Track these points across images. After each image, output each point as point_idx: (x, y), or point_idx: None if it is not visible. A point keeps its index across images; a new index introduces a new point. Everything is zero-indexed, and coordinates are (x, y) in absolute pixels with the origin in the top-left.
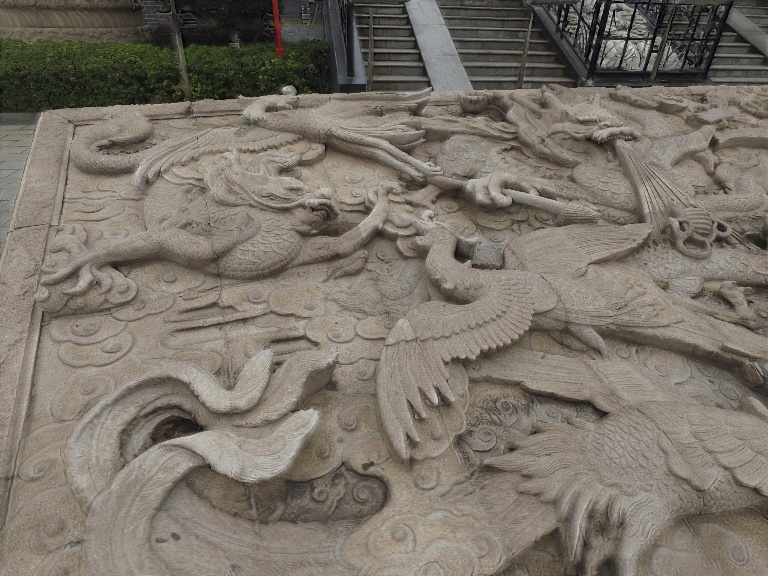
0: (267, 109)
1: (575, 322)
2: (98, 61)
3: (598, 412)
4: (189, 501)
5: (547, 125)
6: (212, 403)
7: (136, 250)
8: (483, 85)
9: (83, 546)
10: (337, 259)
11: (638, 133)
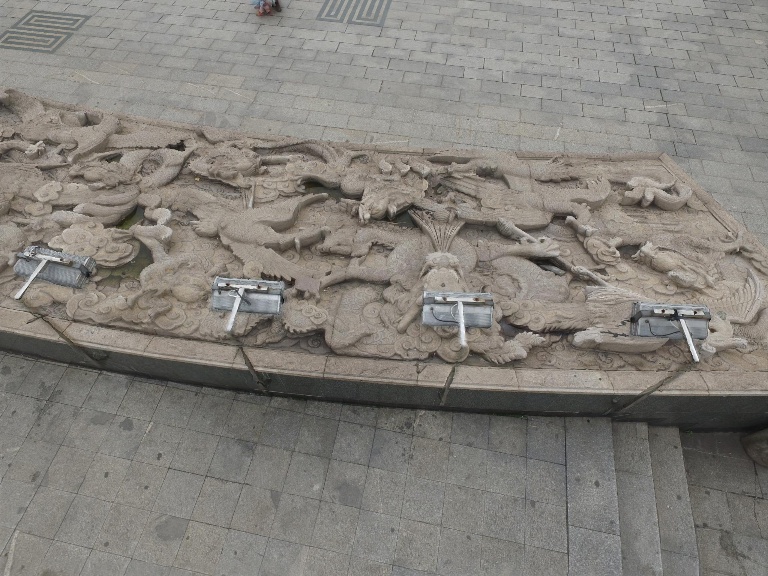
0: None
1: None
2: None
3: None
4: None
5: None
6: (658, 189)
7: None
8: None
9: None
10: None
11: None
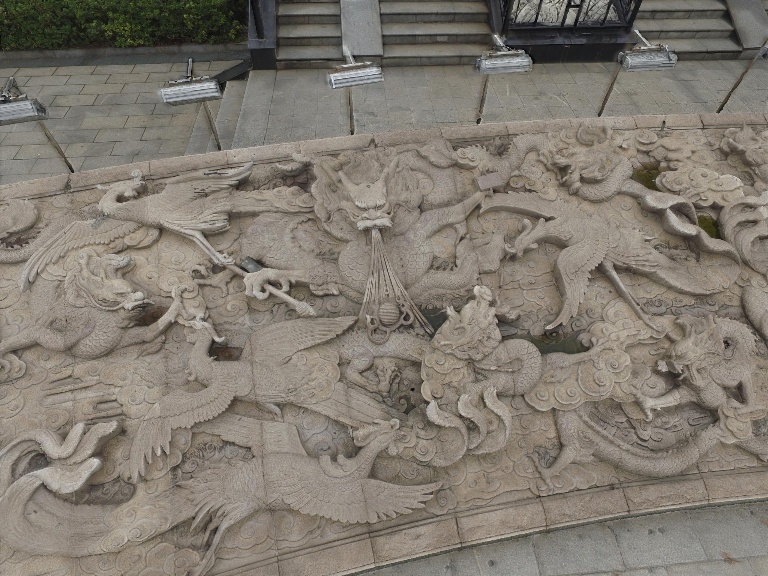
0: (117, 197)
1: (260, 401)
2: None
3: None
4: (44, 495)
5: (339, 200)
6: (50, 455)
7: (21, 345)
8: (398, 39)
9: None
10: (145, 343)
11: (389, 224)
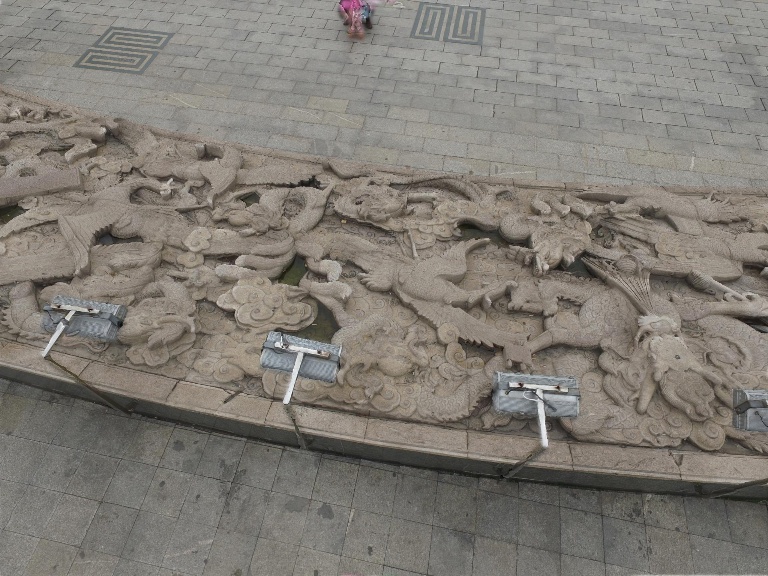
0: None
1: None
2: None
3: None
4: None
5: None
6: None
7: None
8: None
9: None
10: None
11: None
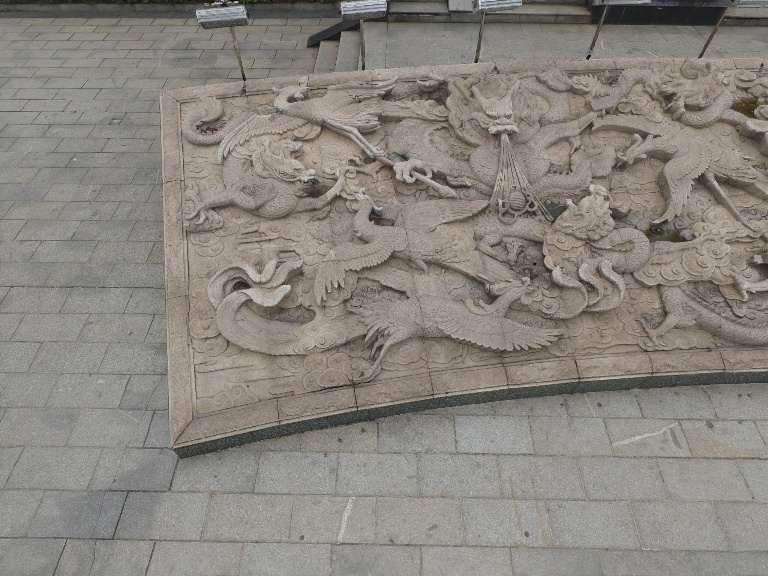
0: (288, 98)
1: (413, 257)
2: None
3: (407, 297)
4: (247, 310)
5: (470, 111)
6: (254, 279)
7: (222, 202)
8: None
9: (216, 319)
10: (315, 210)
11: (517, 130)
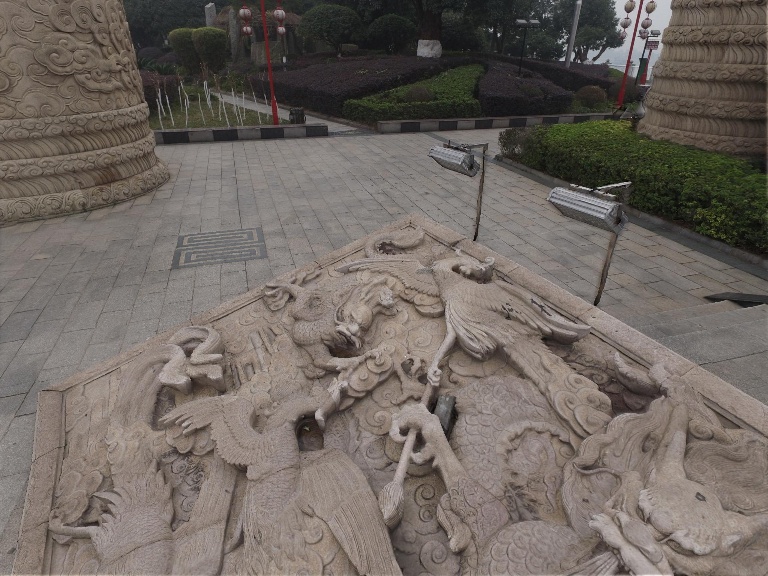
0: (456, 266)
1: (243, 501)
2: (658, 169)
3: None
4: None
5: (635, 465)
6: None
7: None
8: None
9: None
10: None
11: None
